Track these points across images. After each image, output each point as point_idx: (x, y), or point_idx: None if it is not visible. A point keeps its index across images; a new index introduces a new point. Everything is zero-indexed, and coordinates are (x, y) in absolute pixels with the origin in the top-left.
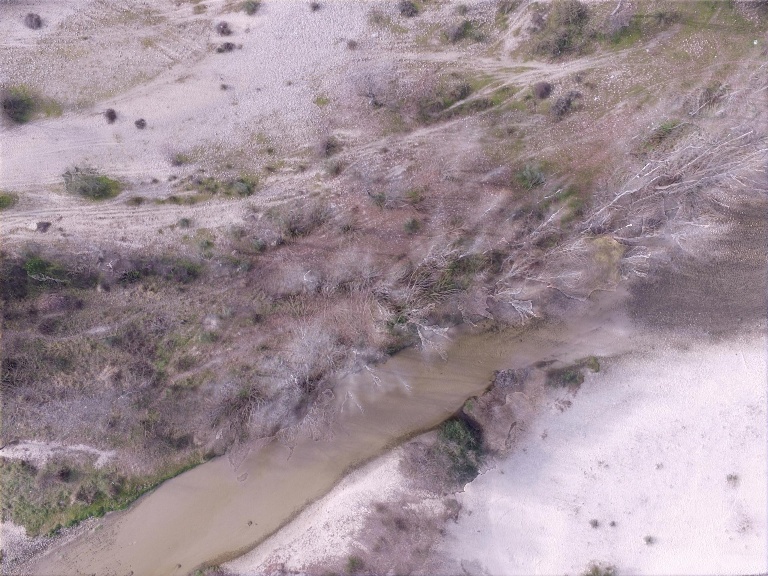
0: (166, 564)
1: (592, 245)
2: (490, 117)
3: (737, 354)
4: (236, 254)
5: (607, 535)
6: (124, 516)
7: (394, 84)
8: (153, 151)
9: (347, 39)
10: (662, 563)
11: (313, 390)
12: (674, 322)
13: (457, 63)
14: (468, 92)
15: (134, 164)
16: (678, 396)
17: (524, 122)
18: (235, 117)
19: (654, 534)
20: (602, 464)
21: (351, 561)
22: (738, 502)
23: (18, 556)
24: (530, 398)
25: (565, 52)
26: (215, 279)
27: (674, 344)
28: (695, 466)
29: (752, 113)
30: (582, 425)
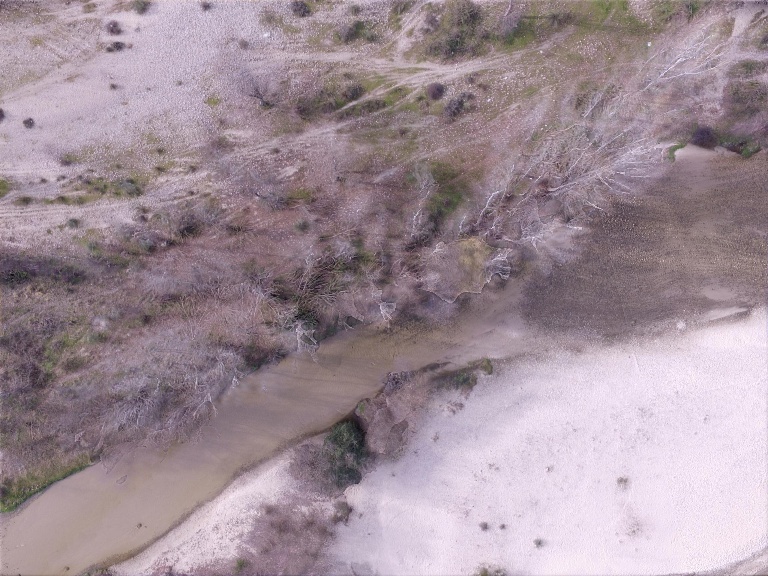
0: (54, 567)
1: (457, 247)
2: (383, 118)
3: (630, 357)
4: (125, 255)
5: (497, 538)
6: (12, 518)
7: (286, 84)
8: (42, 151)
9: (239, 39)
10: (552, 566)
11: (202, 392)
12: (568, 324)
13: (350, 63)
14: (360, 93)
15: (22, 164)
16: (570, 399)
17: (417, 123)
18: (125, 117)
19: (544, 537)
20: (492, 467)
21: (239, 564)
22: (628, 505)
23: None
24: (423, 400)
25: (458, 53)
26: (105, 280)
27: (567, 346)
28: (586, 469)
29: (646, 115)
30: (474, 427)
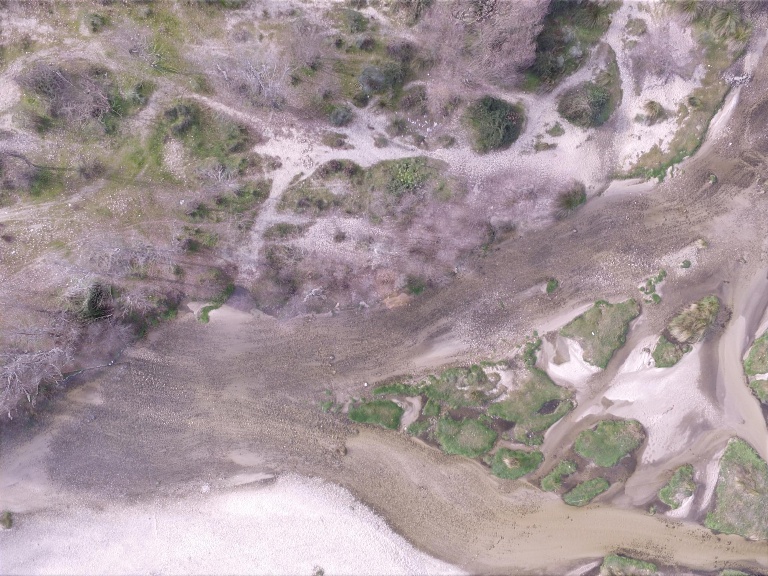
0: None
1: None
2: None
3: (150, 518)
4: None
5: None
6: None
7: None
8: None
9: None
10: None
11: None
12: (92, 482)
13: None
14: None
15: None
16: (83, 559)
17: None
18: None
19: None
20: None
21: None
22: None
23: None
24: None
25: None
26: None
27: (89, 504)
28: None
29: (175, 275)
30: None
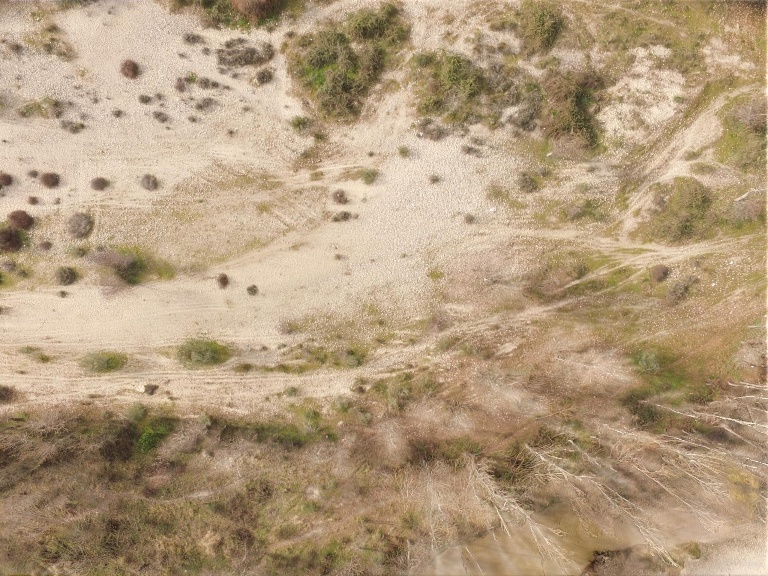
0: None
1: (728, 480)
2: (605, 298)
3: None
4: (342, 425)
5: None
6: None
7: (510, 261)
8: (264, 318)
9: (464, 213)
10: None
11: (414, 566)
12: None
13: (574, 242)
14: (584, 272)
15: (244, 330)
16: None
17: (639, 305)
18: (348, 287)
19: None
20: None
21: None
22: None
23: None
24: None
25: (685, 236)
26: (319, 448)
27: None
28: None
29: None
30: None
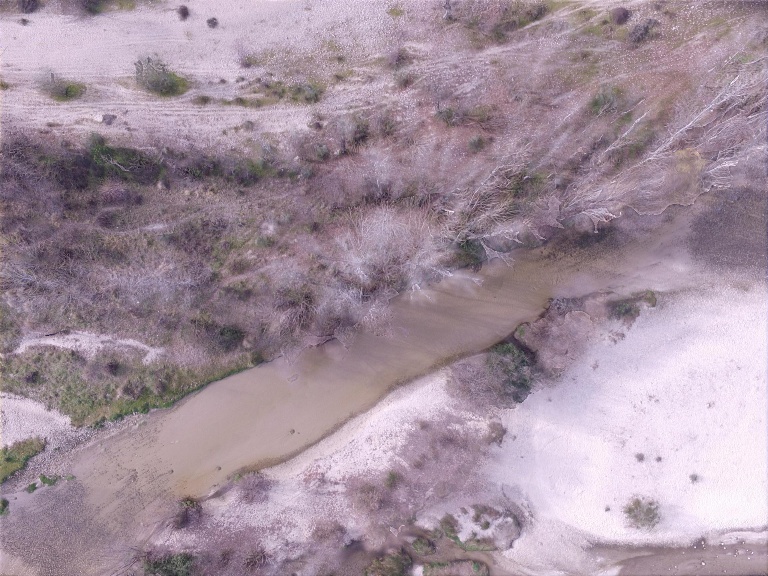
0: (206, 465)
1: (673, 156)
2: (564, 40)
3: None
4: (298, 160)
5: (653, 470)
6: (168, 414)
7: None
8: (223, 51)
9: None
10: (706, 503)
11: (366, 302)
12: (736, 262)
13: None
14: (544, 13)
15: (203, 63)
16: (735, 336)
17: (599, 47)
18: (307, 22)
19: (700, 473)
20: (653, 399)
21: (392, 476)
22: None
23: (61, 445)
24: None
25: None
26: (275, 184)
27: (734, 284)
28: (748, 408)
29: None
30: (635, 359)
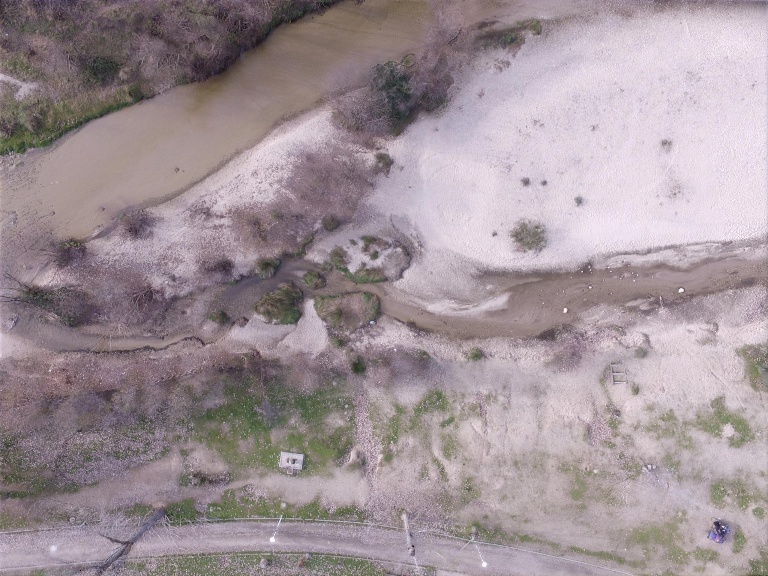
0: (89, 206)
1: None
2: None
3: (682, 23)
4: None
5: (538, 194)
6: (46, 155)
7: None
8: None
9: None
10: (592, 226)
11: (245, 29)
12: None
13: None
14: None
15: None
16: (619, 60)
17: None
18: None
19: (585, 196)
20: (538, 123)
21: (278, 207)
22: (671, 168)
23: None
24: (469, 58)
25: None
26: None
27: (619, 10)
28: (631, 129)
29: None
30: (520, 86)
